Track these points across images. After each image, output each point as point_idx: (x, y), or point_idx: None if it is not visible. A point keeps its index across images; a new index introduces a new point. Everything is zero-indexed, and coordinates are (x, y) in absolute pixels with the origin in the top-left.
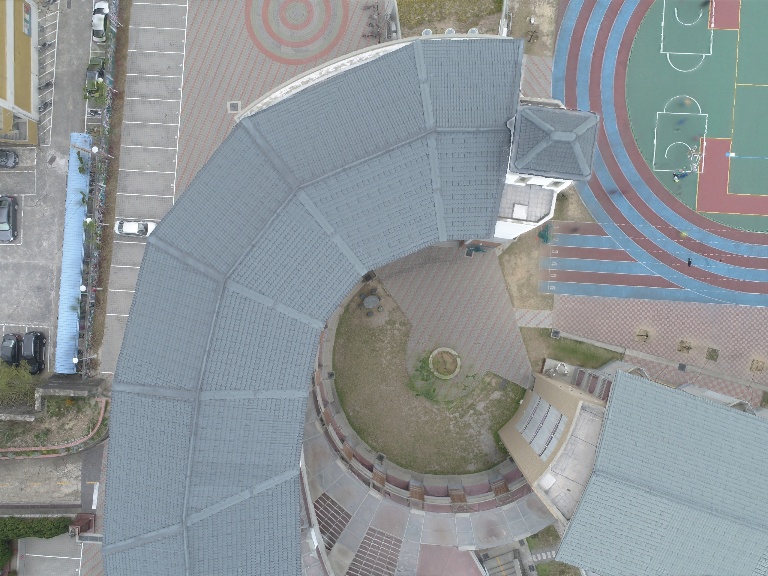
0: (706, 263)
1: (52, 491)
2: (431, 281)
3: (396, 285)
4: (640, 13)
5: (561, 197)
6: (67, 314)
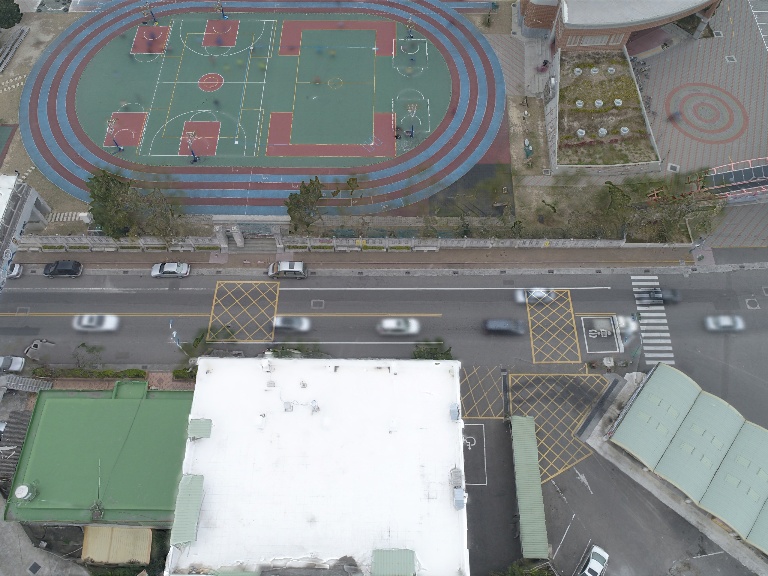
0: None
1: None
2: None
3: None
4: (446, 121)
5: (489, 18)
6: None
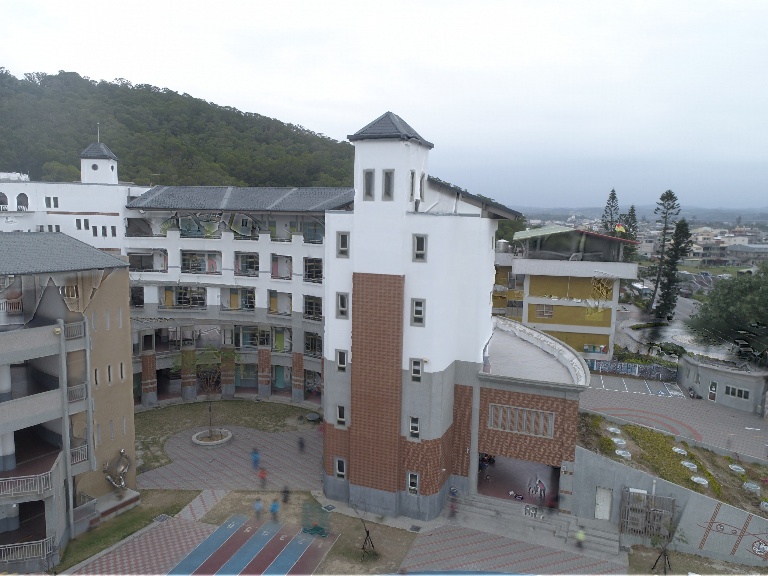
0: None
1: None
2: (311, 448)
3: (321, 432)
4: None
5: None
6: None
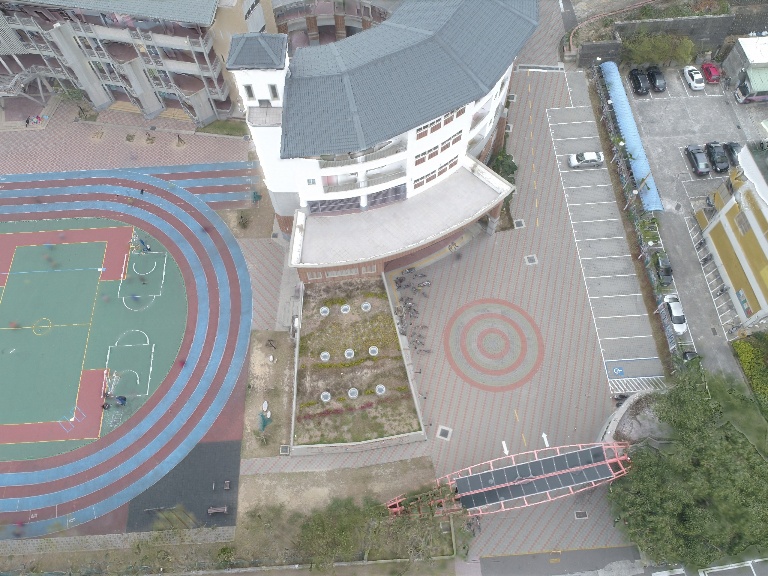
0: (129, 193)
1: (591, 1)
2: None
3: None
4: (171, 377)
5: (244, 219)
6: (619, 94)
